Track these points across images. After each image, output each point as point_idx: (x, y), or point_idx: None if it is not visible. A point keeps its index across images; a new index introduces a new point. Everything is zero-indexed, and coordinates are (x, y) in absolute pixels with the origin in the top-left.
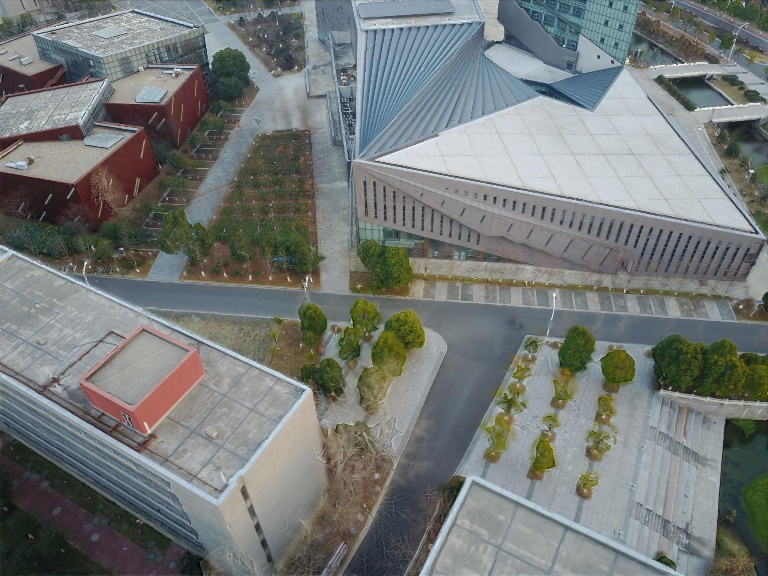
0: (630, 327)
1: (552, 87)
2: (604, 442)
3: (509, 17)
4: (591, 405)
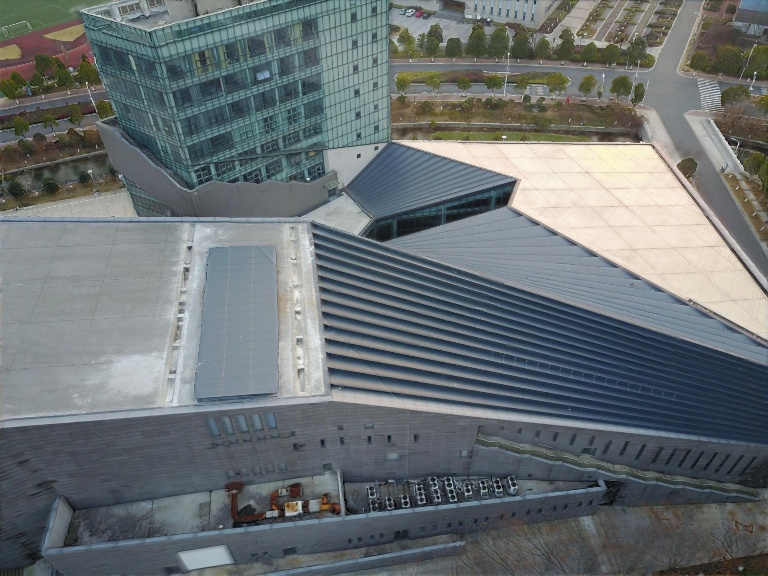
0: (746, 253)
1: (392, 215)
2: None
3: (222, 208)
4: None
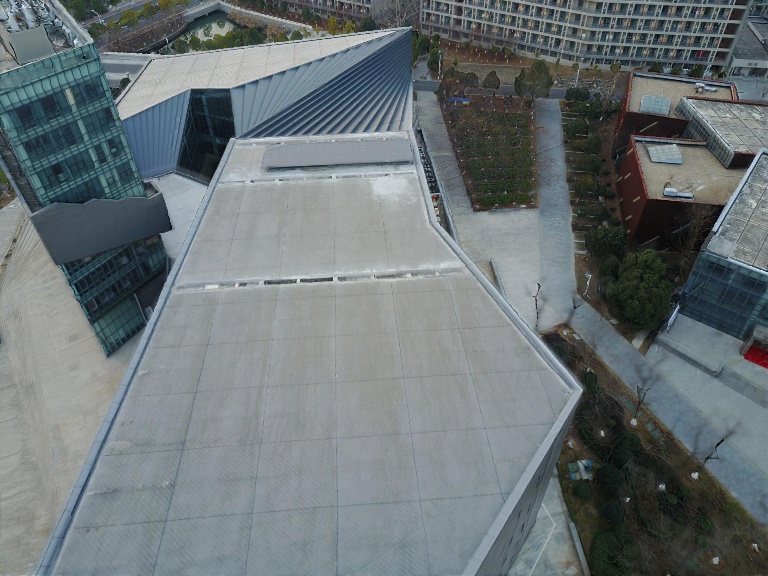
0: None
1: None
2: (306, 30)
3: None
4: None
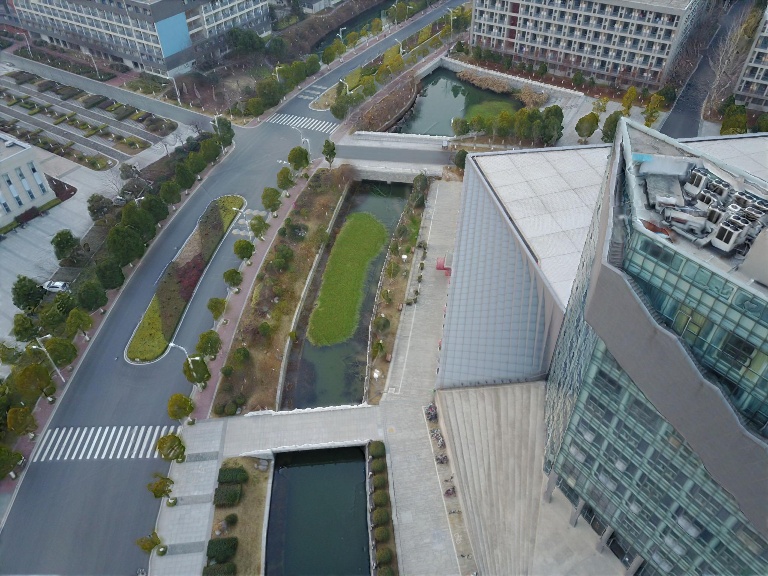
0: None
1: None
2: None
3: None
4: (596, 135)
